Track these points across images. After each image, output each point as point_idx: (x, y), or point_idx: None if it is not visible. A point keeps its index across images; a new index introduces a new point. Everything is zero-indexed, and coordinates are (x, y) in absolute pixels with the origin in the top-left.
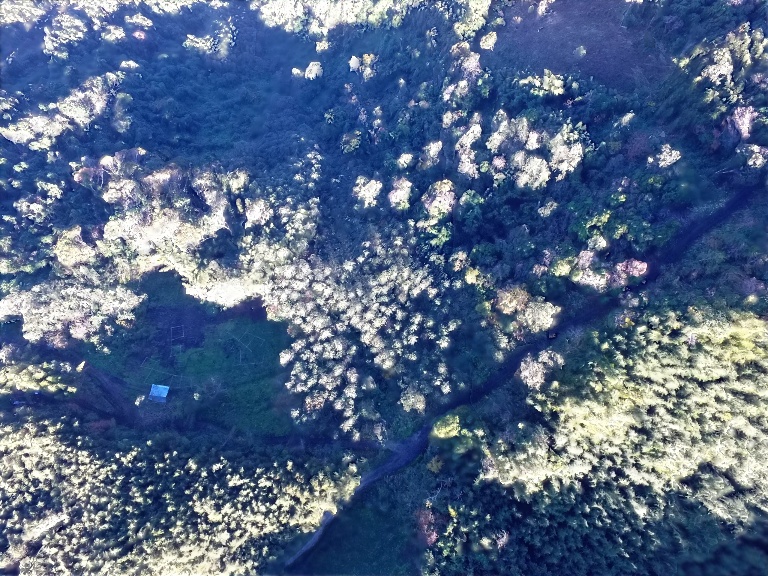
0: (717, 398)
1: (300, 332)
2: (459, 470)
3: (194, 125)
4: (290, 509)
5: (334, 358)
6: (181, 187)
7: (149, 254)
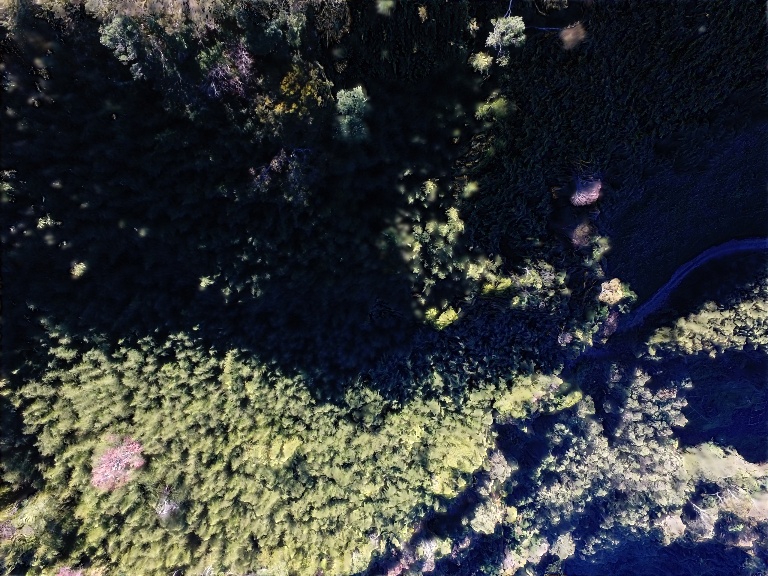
0: (357, 492)
1: (656, 436)
2: (564, 364)
3: (674, 551)
4: (724, 321)
5: (635, 423)
6: (719, 525)
7: (765, 477)
